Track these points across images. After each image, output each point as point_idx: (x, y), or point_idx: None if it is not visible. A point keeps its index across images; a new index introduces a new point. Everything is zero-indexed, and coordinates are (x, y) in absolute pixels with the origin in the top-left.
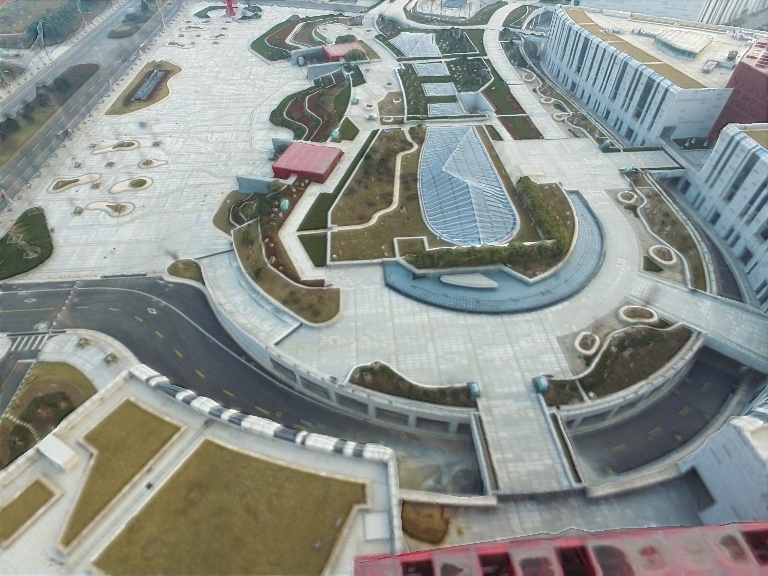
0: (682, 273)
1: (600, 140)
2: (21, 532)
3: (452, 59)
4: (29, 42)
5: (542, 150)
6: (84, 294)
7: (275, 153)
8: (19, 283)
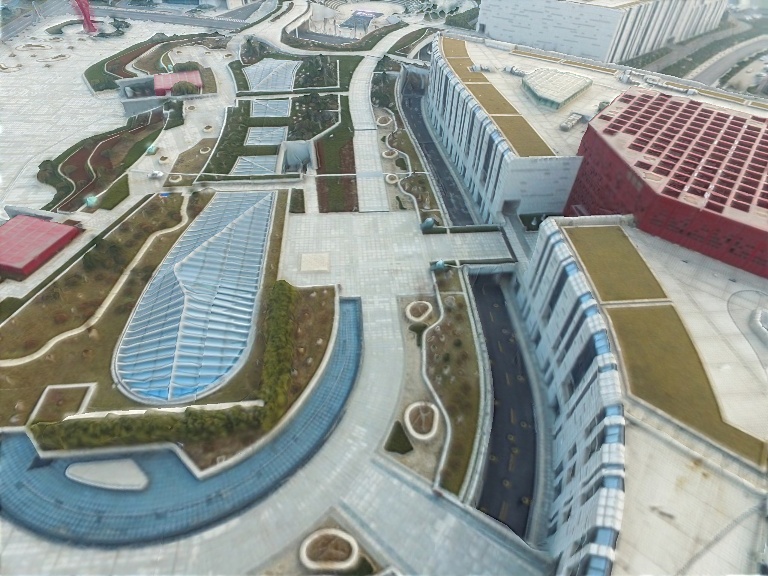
0: (438, 455)
1: (426, 215)
2: None
3: (303, 95)
4: None
5: (346, 229)
6: None
7: None
8: None
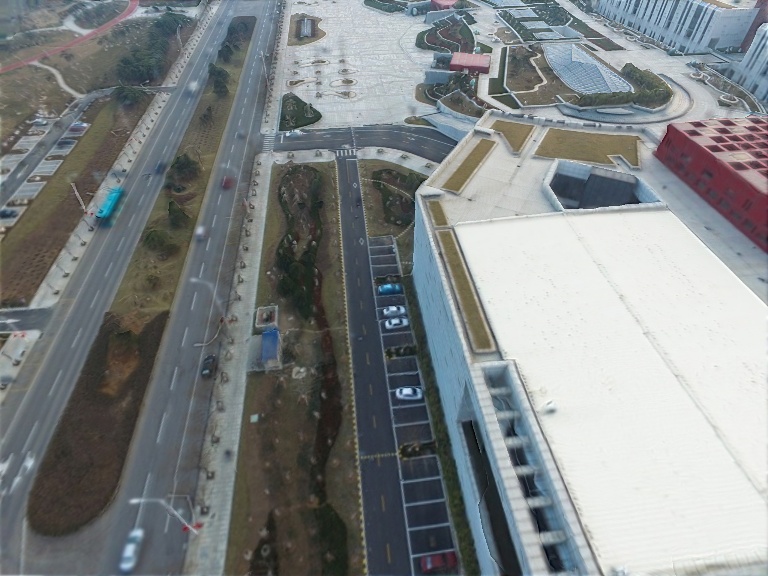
0: (743, 107)
1: (667, 49)
2: (492, 150)
3: (535, 7)
4: (184, 3)
5: (628, 55)
6: (360, 133)
7: (436, 63)
8: (312, 129)
